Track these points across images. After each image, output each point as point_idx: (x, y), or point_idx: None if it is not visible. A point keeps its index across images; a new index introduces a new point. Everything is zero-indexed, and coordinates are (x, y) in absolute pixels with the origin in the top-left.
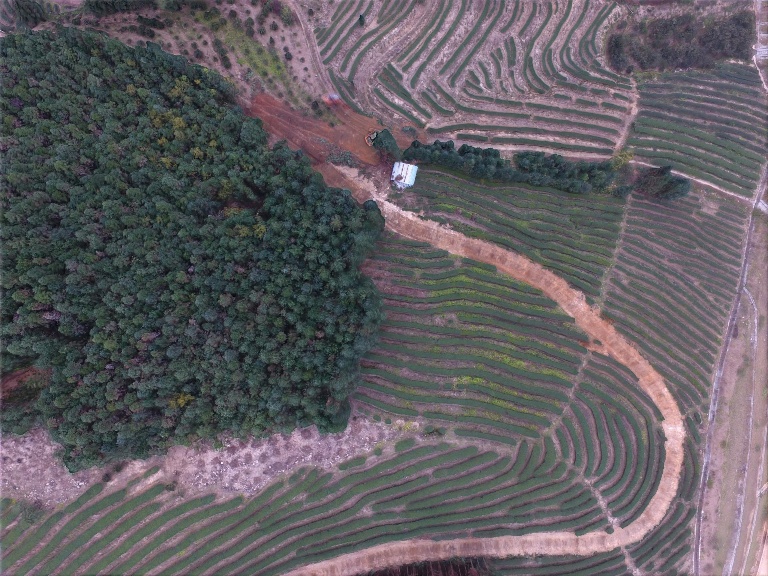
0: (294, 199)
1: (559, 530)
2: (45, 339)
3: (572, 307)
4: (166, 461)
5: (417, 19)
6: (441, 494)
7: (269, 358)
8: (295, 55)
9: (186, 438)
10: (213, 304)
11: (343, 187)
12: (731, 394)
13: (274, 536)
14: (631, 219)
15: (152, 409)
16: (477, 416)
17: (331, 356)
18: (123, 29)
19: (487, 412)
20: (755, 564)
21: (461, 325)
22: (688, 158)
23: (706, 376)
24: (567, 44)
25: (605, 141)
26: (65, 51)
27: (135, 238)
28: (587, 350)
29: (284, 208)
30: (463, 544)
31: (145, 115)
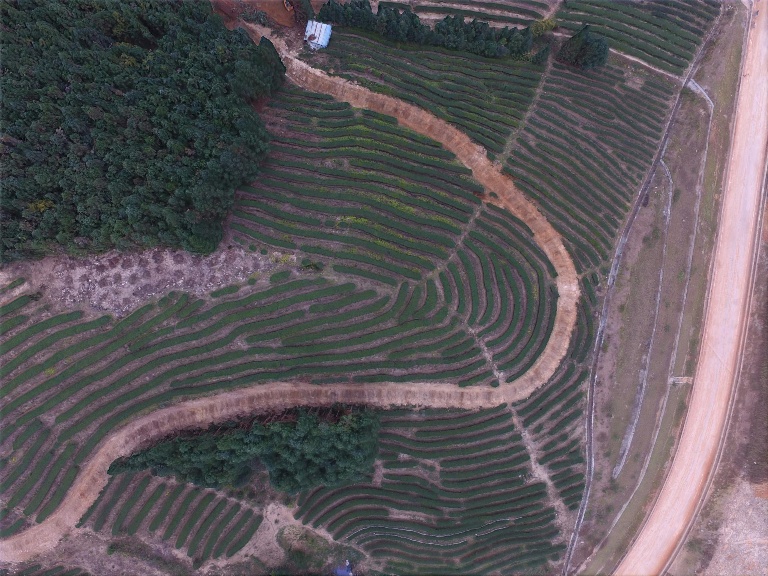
0: (188, 36)
1: (443, 381)
2: None
3: (472, 161)
4: (33, 274)
5: None
6: (318, 331)
7: (133, 168)
8: None
9: (44, 241)
10: (84, 118)
11: None
12: (634, 260)
13: (146, 363)
14: (548, 86)
15: (13, 214)
16: (358, 254)
17: (198, 171)
18: None
19: (369, 251)
20: (669, 459)
21: (352, 169)
22: (618, 33)
23: (608, 239)
24: None
25: (533, 14)
26: None
27: (10, 52)
28: (482, 202)
29: None
30: (345, 391)
31: None
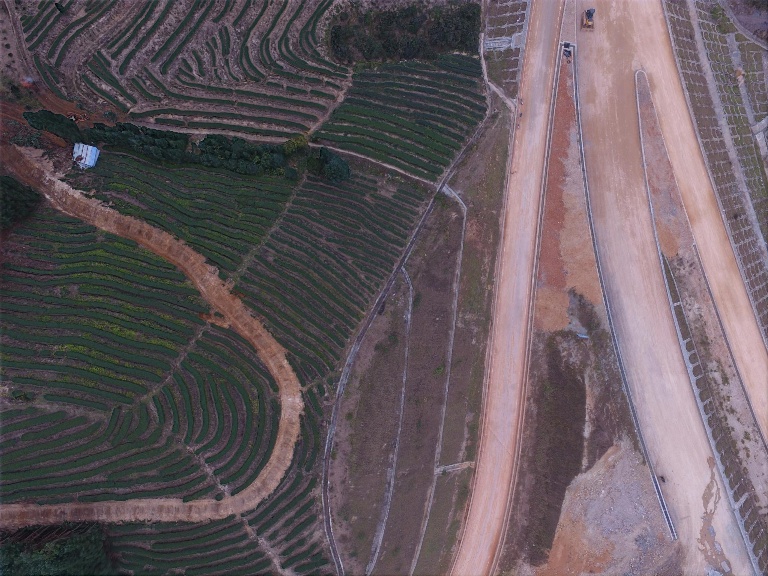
0: None
1: (169, 496)
2: None
3: (204, 281)
4: None
5: (128, 8)
6: (33, 458)
7: None
8: (0, 41)
9: None
10: None
11: (21, 167)
12: (365, 368)
13: None
14: (297, 200)
15: None
16: (71, 382)
17: None
18: None
19: (83, 379)
20: (456, 543)
21: (79, 296)
22: (376, 143)
23: (337, 350)
24: (286, 34)
25: (300, 126)
26: None
27: None
28: (207, 322)
29: None
30: (74, 509)
31: None
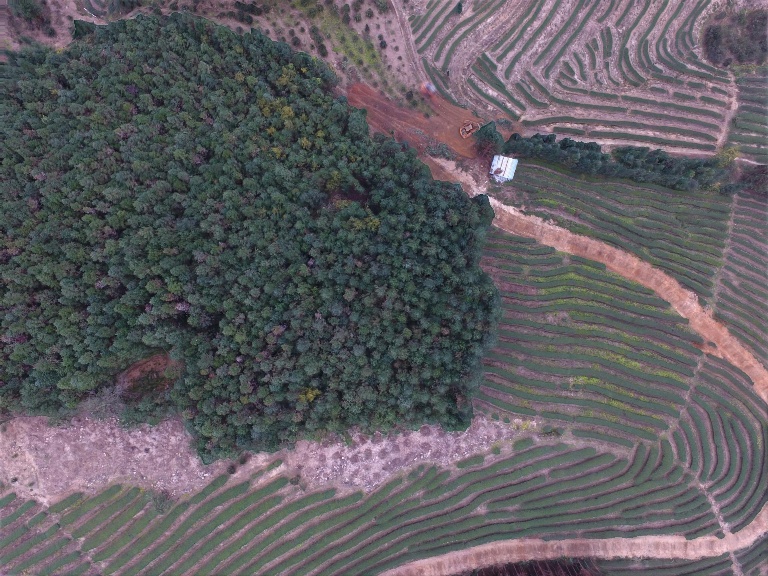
0: (404, 192)
1: (669, 533)
2: (176, 330)
3: (684, 308)
4: (288, 455)
5: (513, 7)
6: (556, 494)
7: (397, 354)
8: (389, 43)
9: (316, 433)
10: (337, 298)
11: (442, 180)
12: None
13: (388, 532)
14: (738, 218)
15: (280, 403)
16: (594, 417)
17: (458, 353)
18: (221, 15)
19: (604, 413)
20: None
21: (574, 324)
22: None
23: None
24: (664, 35)
25: (706, 137)
26: (177, 37)
27: (256, 229)
28: (701, 352)
29: (397, 201)
30: (571, 544)
31: (253, 104)
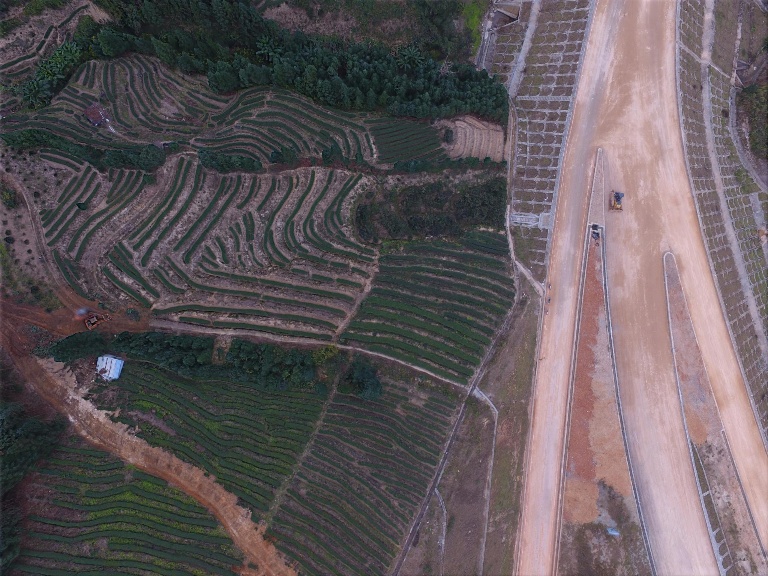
0: None
1: None
2: None
3: (236, 525)
4: None
5: (150, 198)
6: None
7: None
8: (19, 237)
9: None
10: None
11: (43, 382)
12: None
13: None
14: (328, 417)
15: None
16: None
17: None
18: None
19: None
20: None
21: (109, 553)
22: (405, 344)
23: None
24: (311, 216)
25: (327, 324)
26: None
27: None
28: (241, 575)
29: None
30: None
31: None
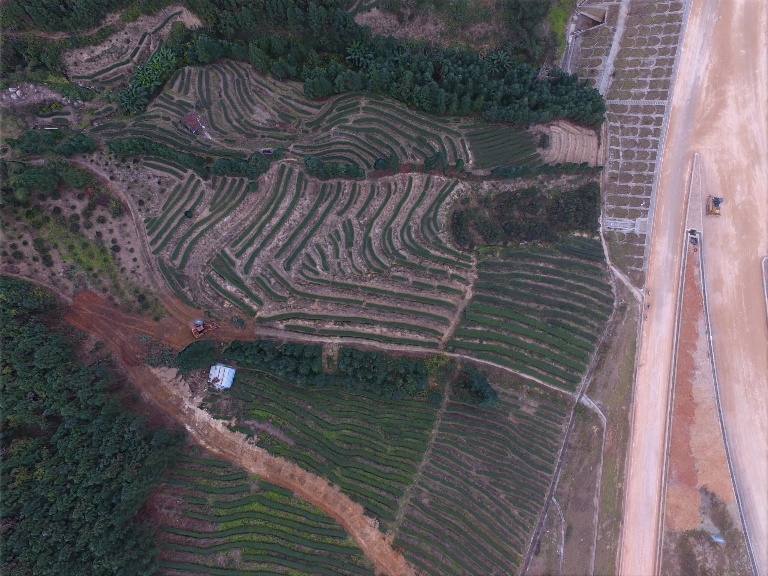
0: (82, 432)
1: None
2: None
3: (364, 535)
4: None
5: (251, 205)
6: None
7: None
8: (124, 246)
9: None
10: None
11: (158, 392)
12: None
13: None
14: (443, 426)
15: None
16: None
17: None
18: None
19: None
20: None
21: (243, 564)
22: (513, 352)
23: None
24: (408, 222)
25: (433, 332)
26: None
27: None
28: None
29: (67, 447)
30: None
31: None
